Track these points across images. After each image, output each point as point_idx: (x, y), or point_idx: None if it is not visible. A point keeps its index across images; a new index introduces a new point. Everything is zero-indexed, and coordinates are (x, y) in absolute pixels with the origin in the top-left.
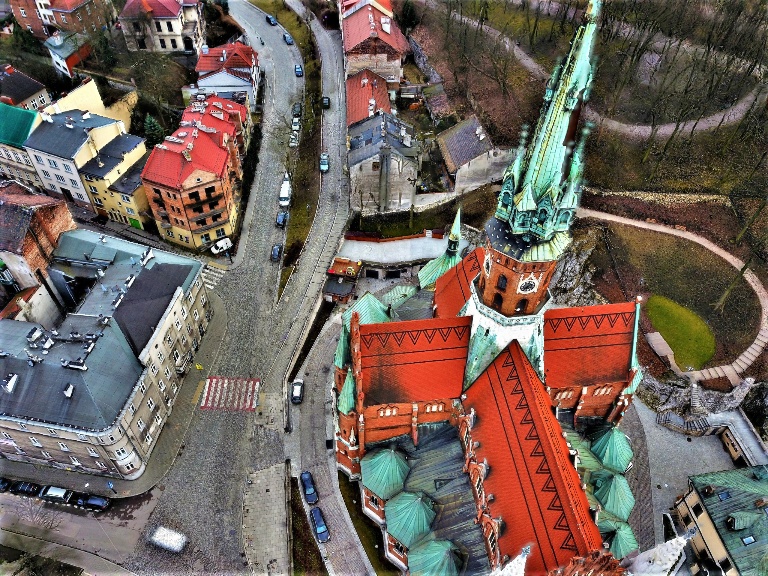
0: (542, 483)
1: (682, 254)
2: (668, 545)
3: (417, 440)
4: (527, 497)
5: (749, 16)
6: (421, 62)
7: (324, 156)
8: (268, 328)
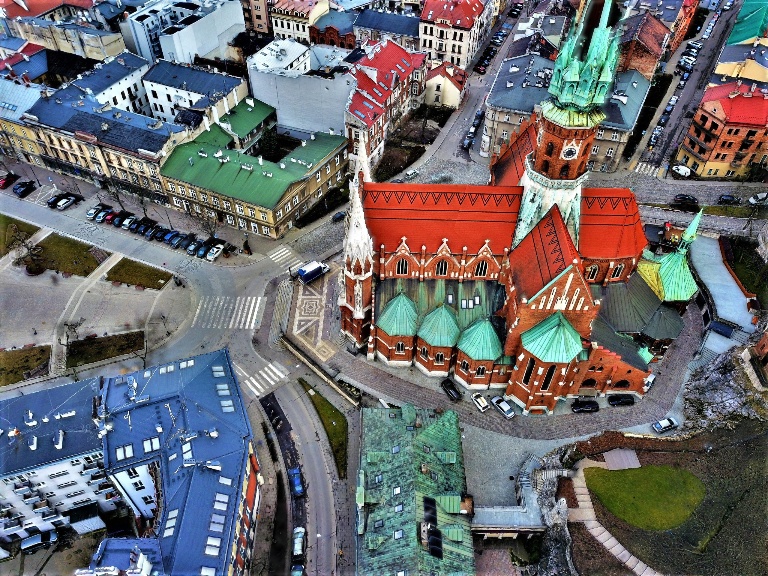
0: None
1: None
2: None
3: None
4: None
5: None
6: None
7: None
8: None
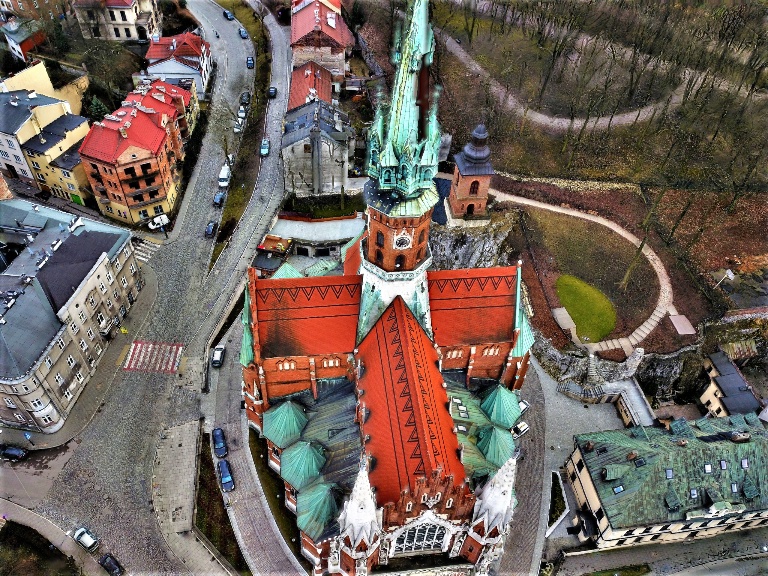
0: (406, 419)
1: (592, 237)
2: (503, 467)
3: (317, 394)
4: (394, 434)
5: (675, 21)
6: (368, 57)
7: (265, 141)
8: (196, 298)
